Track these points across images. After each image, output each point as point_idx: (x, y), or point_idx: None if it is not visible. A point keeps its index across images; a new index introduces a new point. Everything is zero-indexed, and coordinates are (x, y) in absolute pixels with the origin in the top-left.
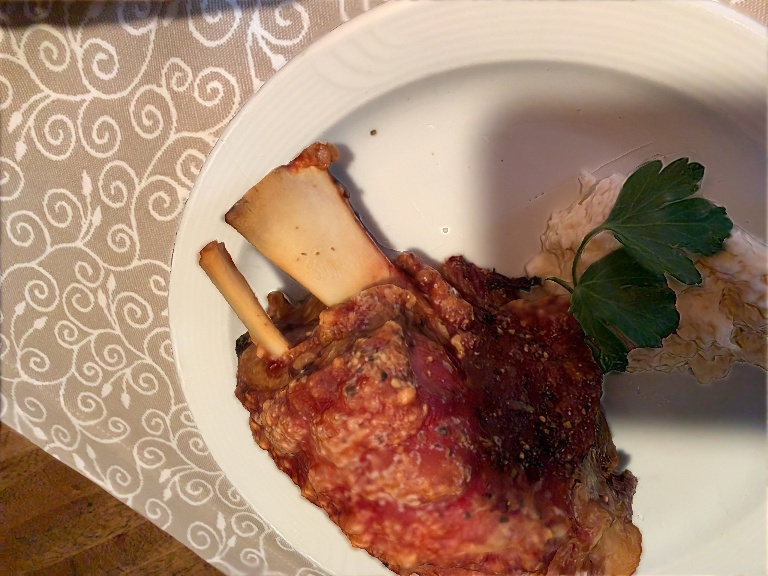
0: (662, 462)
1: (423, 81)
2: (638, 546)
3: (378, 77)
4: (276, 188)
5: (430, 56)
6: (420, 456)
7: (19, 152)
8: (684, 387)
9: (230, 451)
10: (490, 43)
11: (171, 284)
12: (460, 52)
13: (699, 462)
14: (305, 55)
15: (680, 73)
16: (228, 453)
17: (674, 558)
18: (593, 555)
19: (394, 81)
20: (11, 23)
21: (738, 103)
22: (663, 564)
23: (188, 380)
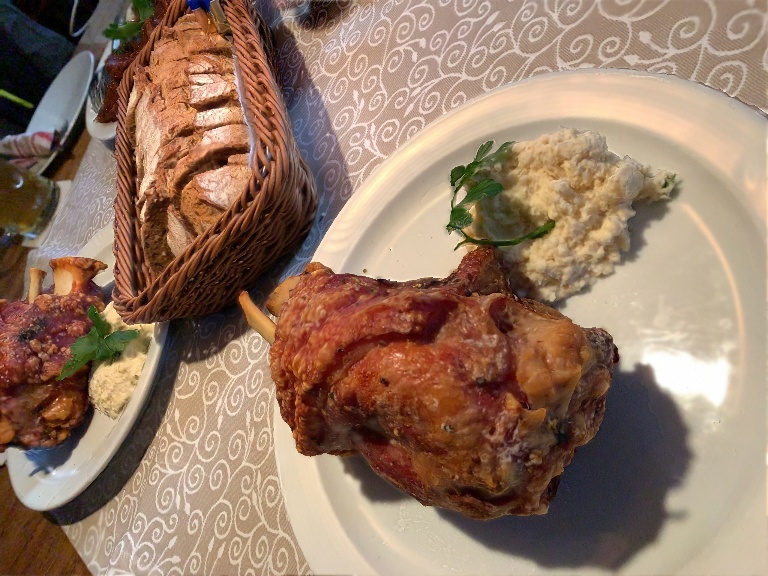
0: (686, 352)
1: (372, 226)
2: (565, 322)
3: (351, 237)
4: (291, 283)
5: (368, 213)
6: (324, 290)
7: (219, 423)
8: (638, 276)
9: (322, 555)
10: (390, 189)
11: (274, 421)
12: (380, 202)
13: (712, 324)
14: (317, 250)
15: (472, 132)
16: (321, 558)
17: (767, 427)
18: (511, 335)
19: (359, 235)
20: (219, 350)
21: (505, 119)
22: (766, 445)
23: (288, 495)
